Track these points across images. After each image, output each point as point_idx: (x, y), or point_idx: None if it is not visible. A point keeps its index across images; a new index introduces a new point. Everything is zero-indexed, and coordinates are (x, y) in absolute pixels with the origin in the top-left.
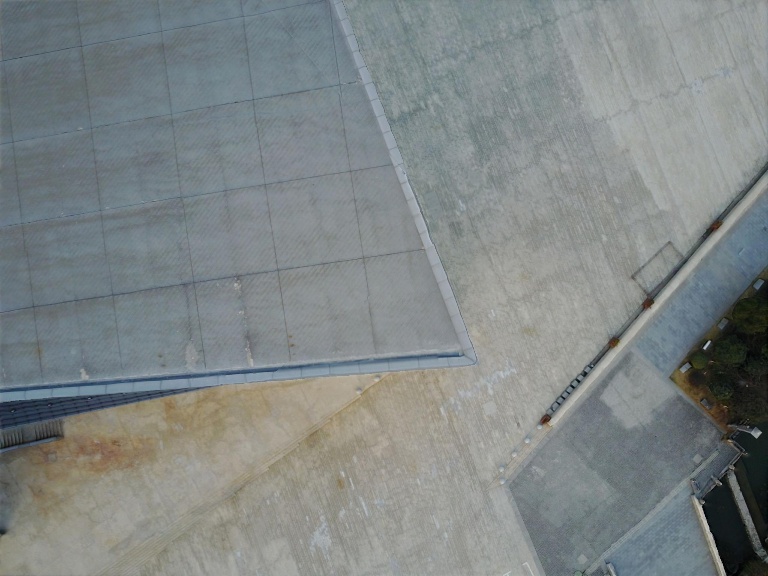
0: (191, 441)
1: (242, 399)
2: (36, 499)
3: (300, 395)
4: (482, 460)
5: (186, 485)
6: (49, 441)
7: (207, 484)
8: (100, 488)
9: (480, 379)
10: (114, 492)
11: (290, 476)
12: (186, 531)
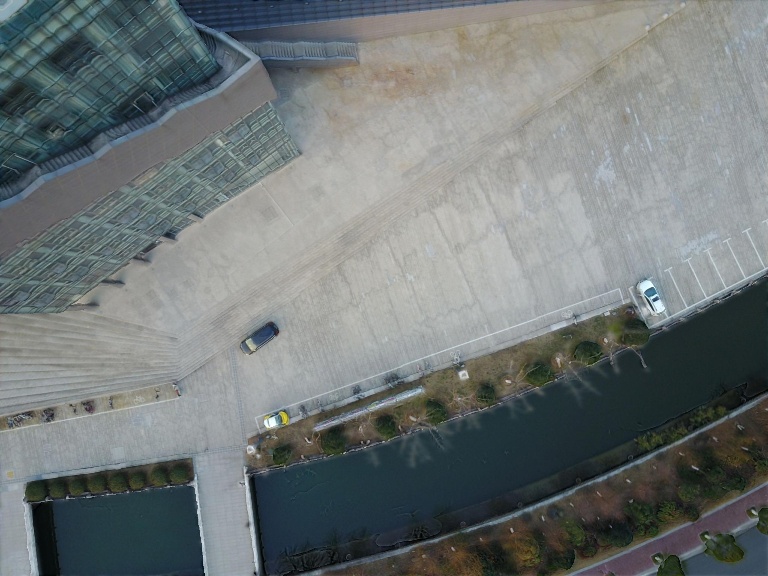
0: (483, 71)
1: (533, 32)
2: (332, 123)
3: (590, 30)
4: (764, 99)
5: (478, 114)
6: (351, 59)
7: (498, 113)
8: (394, 114)
9: (764, 20)
10: (408, 118)
11: (577, 111)
12: (474, 163)
